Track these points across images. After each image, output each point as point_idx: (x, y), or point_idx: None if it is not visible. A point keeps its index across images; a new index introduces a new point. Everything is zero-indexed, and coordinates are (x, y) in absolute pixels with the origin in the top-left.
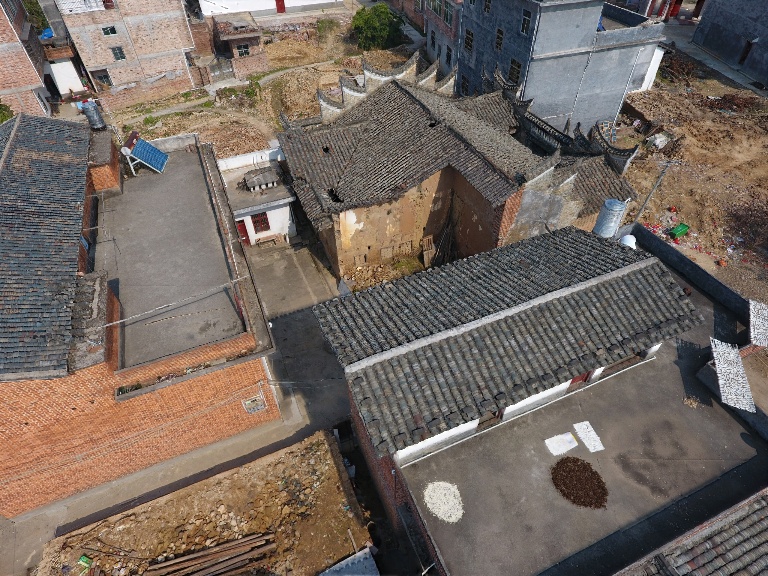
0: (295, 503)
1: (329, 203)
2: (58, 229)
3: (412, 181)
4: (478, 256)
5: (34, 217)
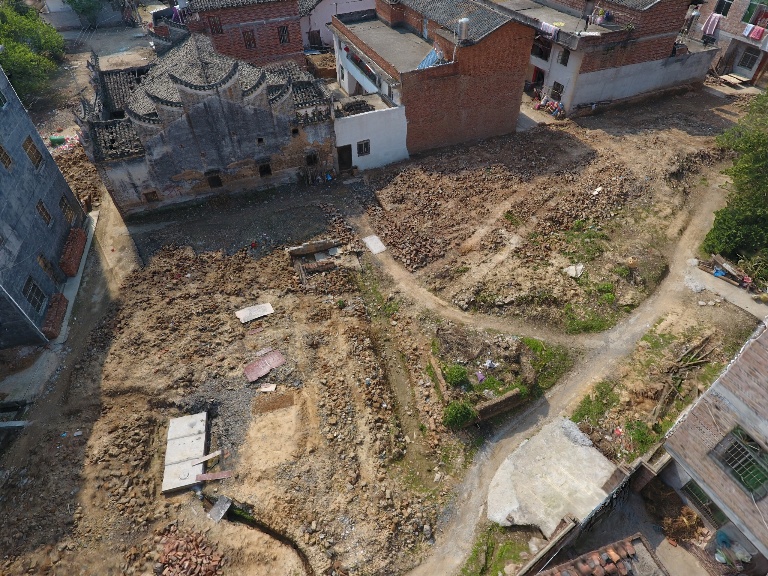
0: (329, 60)
1: (300, 77)
2: (419, 3)
3: (242, 62)
4: None
5: (431, 0)
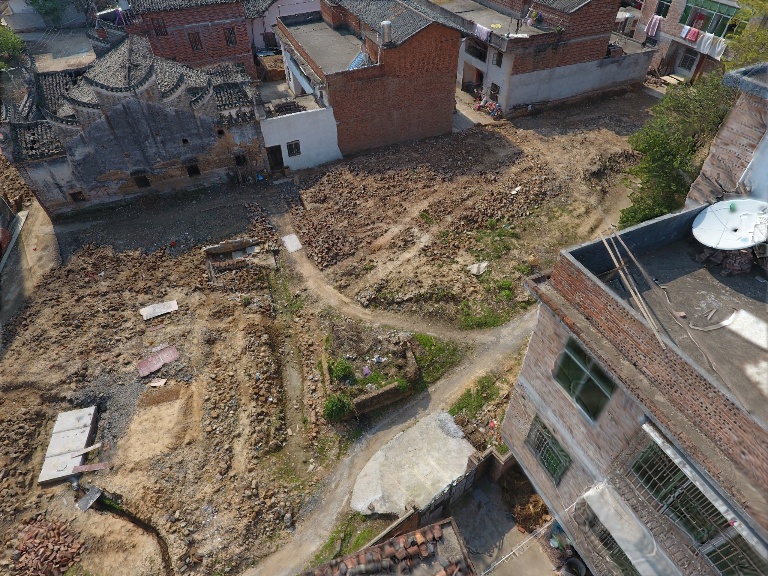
0: None
1: (236, 79)
2: None
3: None
4: (182, 6)
5: None
